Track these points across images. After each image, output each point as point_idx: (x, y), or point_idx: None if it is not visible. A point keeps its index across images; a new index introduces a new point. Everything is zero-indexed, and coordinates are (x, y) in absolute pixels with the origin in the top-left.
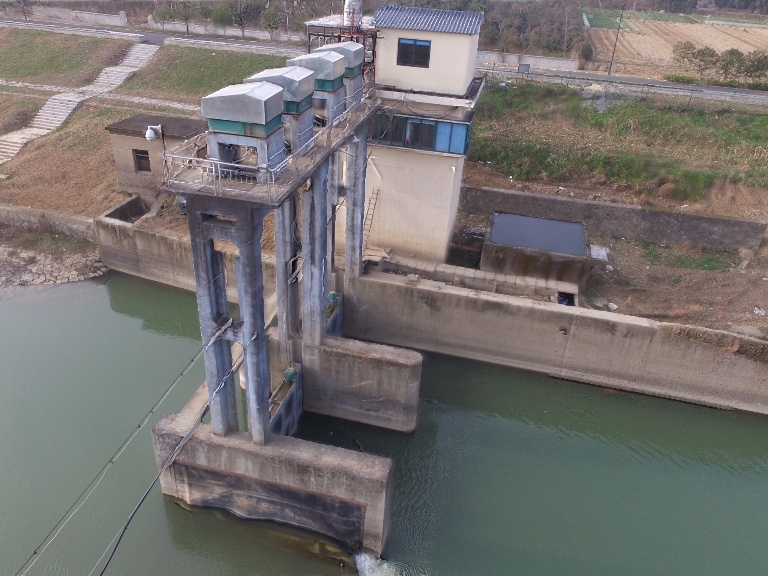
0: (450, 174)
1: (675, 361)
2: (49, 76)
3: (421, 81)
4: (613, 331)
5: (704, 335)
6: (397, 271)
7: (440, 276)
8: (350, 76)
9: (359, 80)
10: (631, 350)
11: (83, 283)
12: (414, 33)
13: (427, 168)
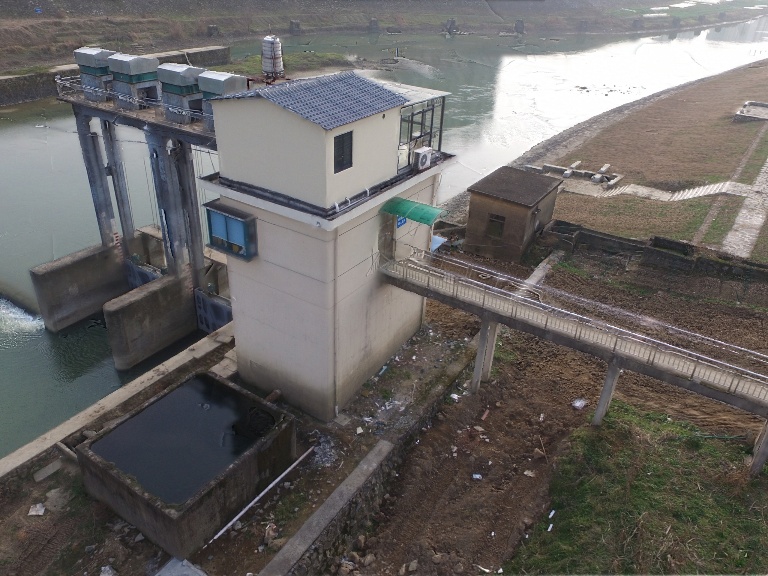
0: None
1: None
2: None
3: None
4: None
5: None
6: None
7: None
8: None
9: None
10: None
11: None
12: None
13: None
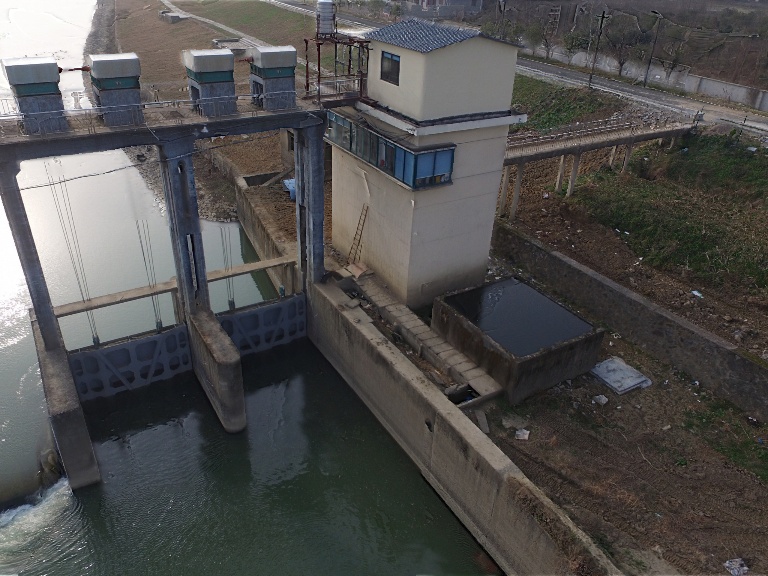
0: (410, 207)
1: (521, 538)
2: None
3: (394, 99)
4: (466, 453)
5: (551, 522)
6: (361, 294)
7: (387, 315)
8: (263, 76)
9: (282, 83)
10: (482, 491)
11: (213, 223)
12: (389, 47)
13: (396, 195)
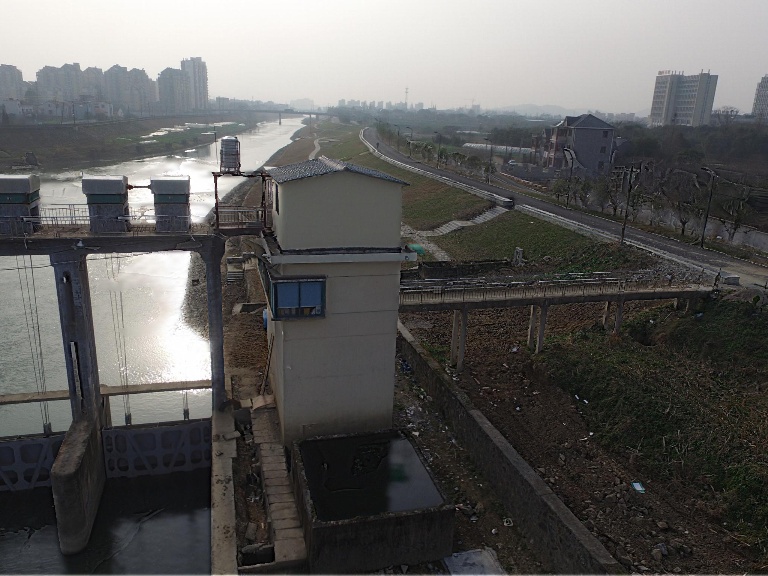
0: None
1: None
2: (419, 220)
3: None
4: None
5: None
6: None
7: None
8: None
9: (173, 208)
10: None
11: None
12: None
13: None
